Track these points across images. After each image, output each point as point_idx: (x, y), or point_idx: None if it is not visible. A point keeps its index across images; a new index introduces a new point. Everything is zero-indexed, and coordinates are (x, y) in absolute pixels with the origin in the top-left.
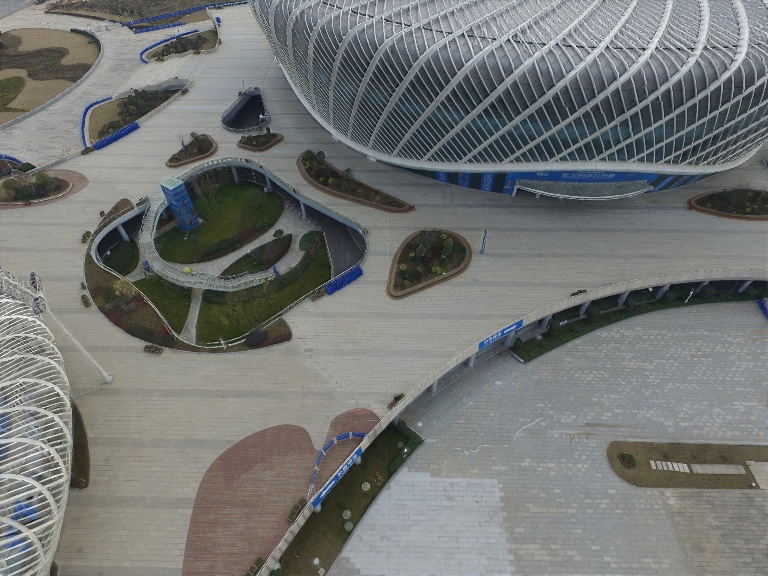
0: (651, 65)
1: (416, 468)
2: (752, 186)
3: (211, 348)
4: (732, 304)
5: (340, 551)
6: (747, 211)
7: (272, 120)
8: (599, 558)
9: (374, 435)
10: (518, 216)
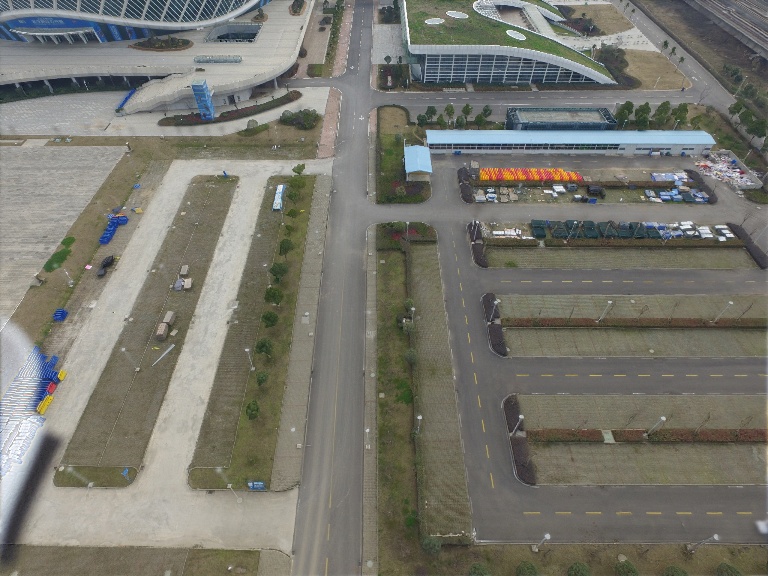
0: None
1: None
2: (186, 38)
3: None
4: (118, 92)
5: None
6: (156, 46)
7: None
8: None
9: None
10: (18, 50)
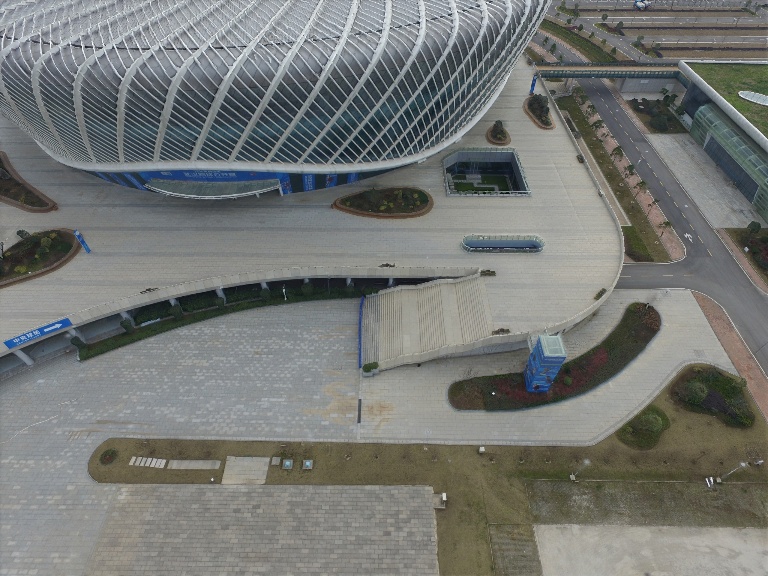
0: (147, 65)
1: None
2: (413, 184)
3: None
4: (335, 301)
5: None
6: (380, 209)
7: None
8: (8, 553)
9: None
10: (155, 215)
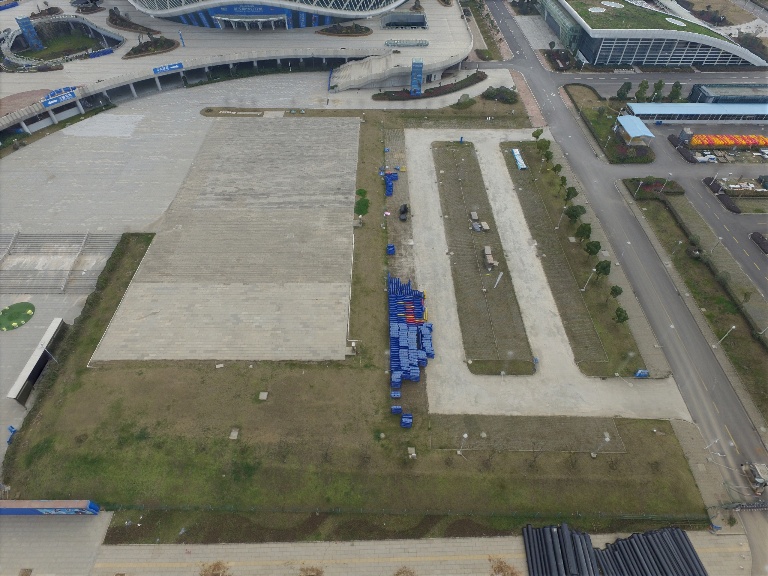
0: None
1: (108, 113)
2: None
3: (20, 72)
4: None
5: (59, 130)
6: (342, 32)
7: (104, 2)
8: None
9: (83, 91)
10: None
